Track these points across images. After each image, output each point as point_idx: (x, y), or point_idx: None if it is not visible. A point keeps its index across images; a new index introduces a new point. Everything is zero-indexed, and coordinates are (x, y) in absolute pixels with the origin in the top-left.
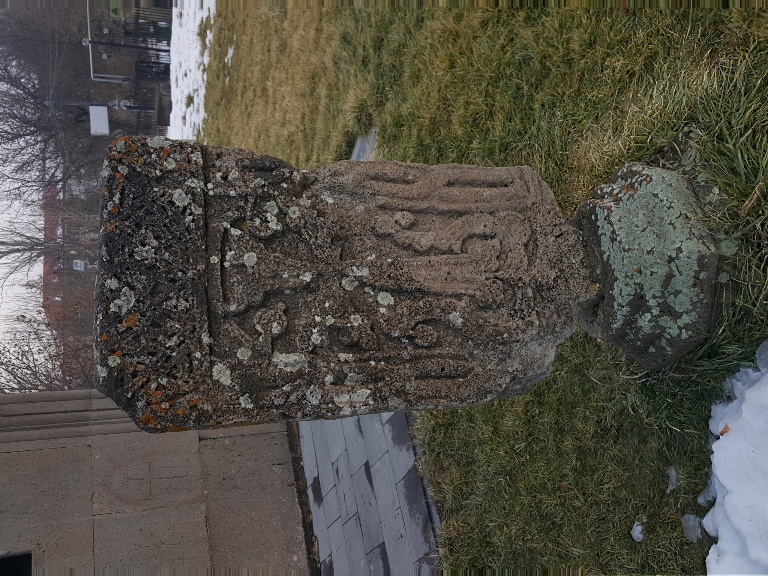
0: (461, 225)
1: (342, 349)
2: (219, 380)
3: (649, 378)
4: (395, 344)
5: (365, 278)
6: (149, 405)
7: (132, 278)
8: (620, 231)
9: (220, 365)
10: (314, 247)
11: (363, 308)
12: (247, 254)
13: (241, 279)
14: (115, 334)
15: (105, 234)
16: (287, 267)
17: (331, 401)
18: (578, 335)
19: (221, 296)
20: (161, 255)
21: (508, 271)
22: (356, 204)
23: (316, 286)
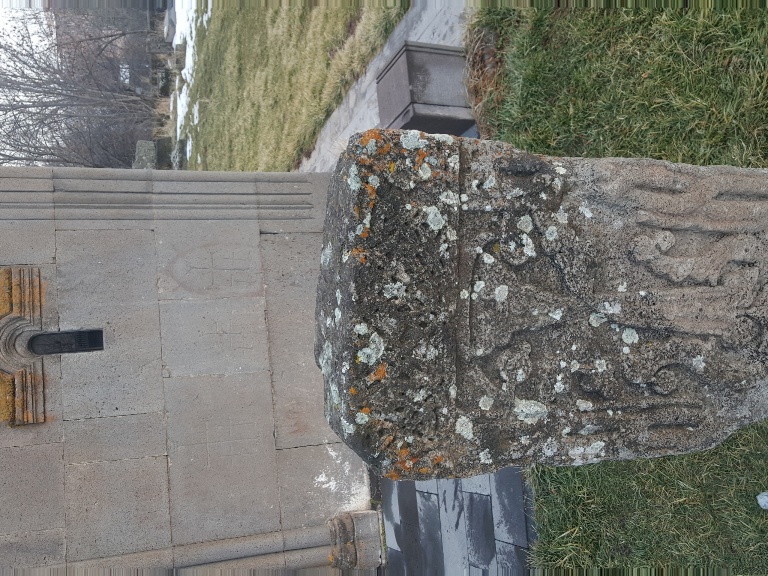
0: (723, 250)
1: (581, 395)
2: (460, 433)
3: None
4: (633, 389)
5: (616, 316)
6: (393, 464)
7: (381, 322)
8: None
9: (463, 418)
10: (568, 278)
11: (607, 348)
12: (499, 288)
13: (490, 318)
14: (363, 389)
15: (354, 267)
16: (538, 303)
17: (565, 454)
18: None
19: (469, 339)
20: (412, 293)
21: (761, 308)
22: (614, 218)
23: (562, 322)
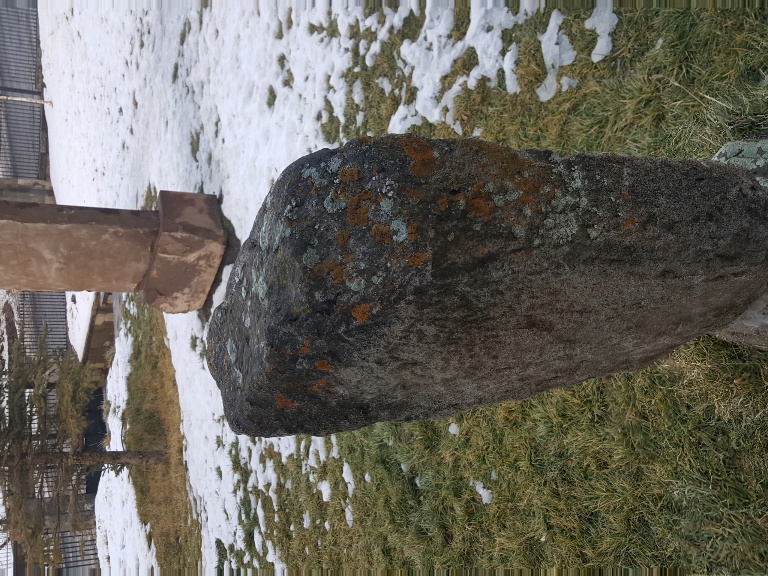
0: None
1: None
2: None
3: None
4: None
5: None
6: None
7: None
8: None
9: None
10: None
11: None
12: None
13: None
14: None
15: None
16: None
17: None
18: None
19: None
20: None
21: None
22: None
23: None
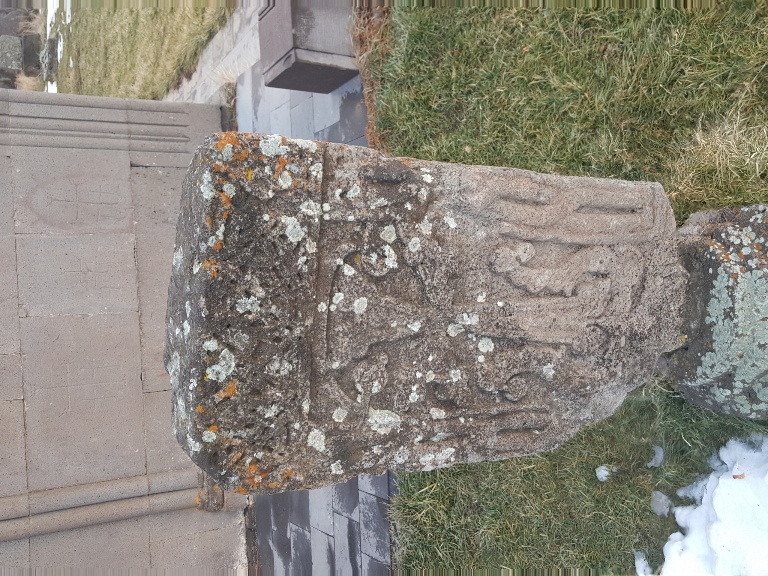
0: (579, 262)
1: (435, 403)
2: (312, 445)
3: (682, 394)
4: (485, 396)
5: (473, 327)
6: (241, 480)
7: (233, 338)
8: (740, 312)
9: (316, 431)
10: (428, 289)
11: (463, 357)
12: (358, 300)
13: (348, 330)
14: (211, 406)
15: (205, 281)
16: (397, 315)
17: (416, 461)
18: None
19: (325, 352)
20: (267, 308)
21: (610, 318)
22: (478, 228)
23: (421, 332)
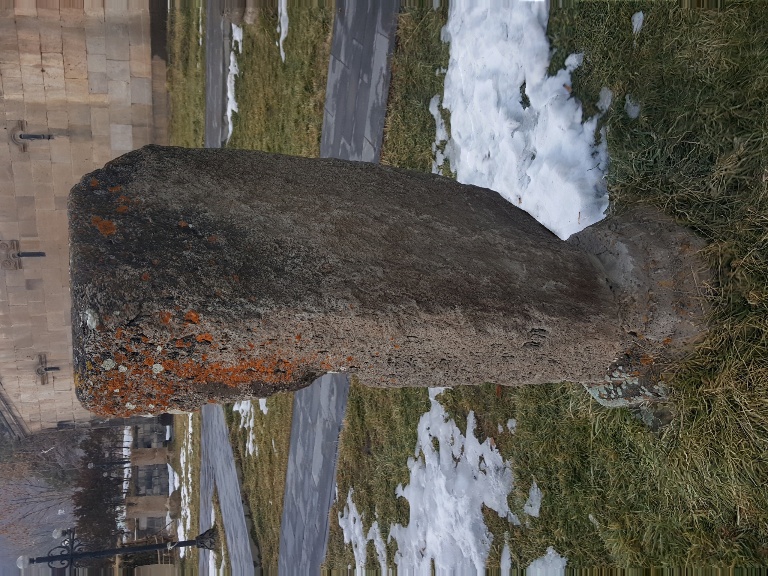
0: None
1: None
2: None
3: None
4: None
5: None
6: None
7: None
8: None
9: None
10: None
11: None
12: None
13: None
14: None
15: None
16: None
17: None
18: (766, 111)
19: None
20: None
21: None
22: None
23: None
